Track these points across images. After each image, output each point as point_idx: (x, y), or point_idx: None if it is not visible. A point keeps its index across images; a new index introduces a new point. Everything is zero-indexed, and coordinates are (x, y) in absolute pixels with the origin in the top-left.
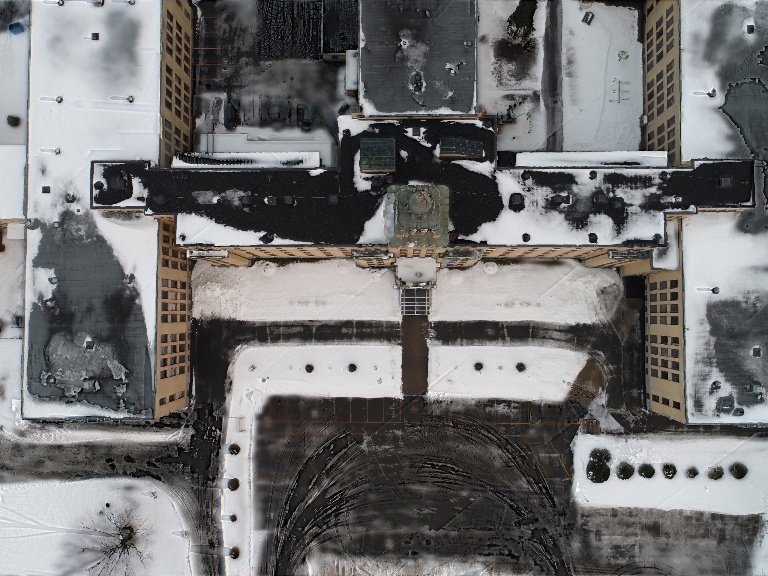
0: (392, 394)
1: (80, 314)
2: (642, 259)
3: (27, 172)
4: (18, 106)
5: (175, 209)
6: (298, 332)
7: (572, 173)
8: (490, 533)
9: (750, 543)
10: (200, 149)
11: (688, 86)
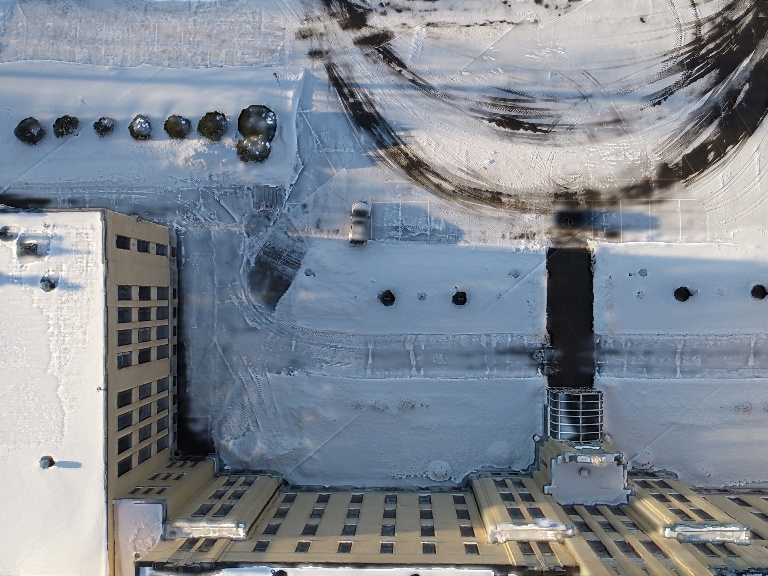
0: (609, 249)
1: None
2: (184, 522)
3: None
4: None
5: None
6: None
7: None
8: (436, 19)
9: (16, 16)
10: None
11: None
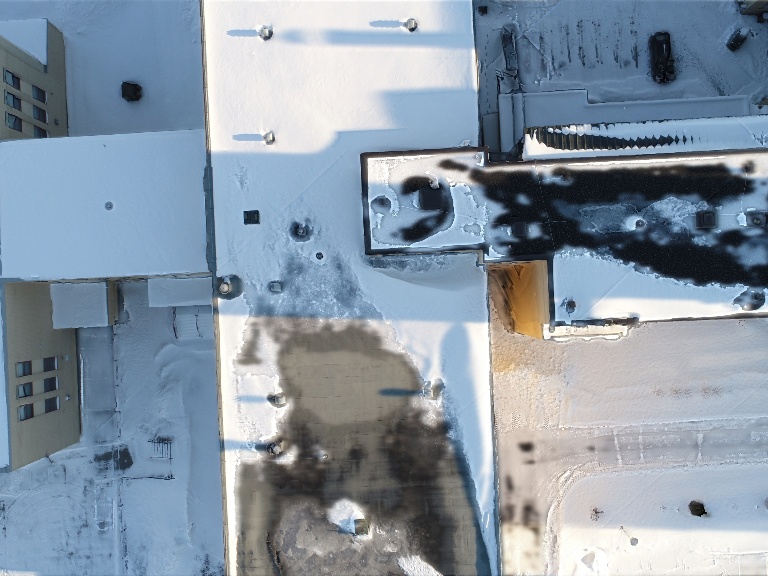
0: None
1: (336, 465)
2: None
3: (210, 183)
4: (137, 65)
5: (546, 246)
6: (671, 444)
7: None
8: None
9: None
10: (500, 123)
11: None
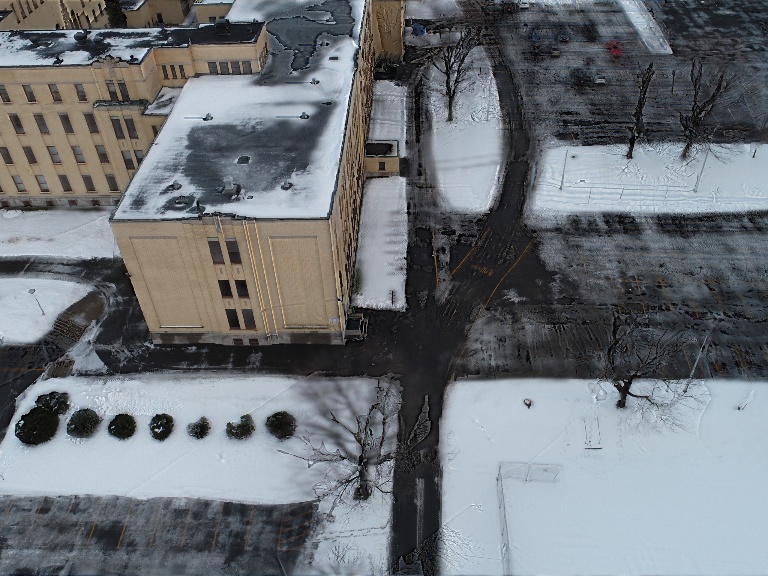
0: None
1: None
2: (130, 105)
3: None
4: None
5: None
6: None
7: (65, 33)
8: None
9: (290, 560)
10: None
11: (231, 19)
